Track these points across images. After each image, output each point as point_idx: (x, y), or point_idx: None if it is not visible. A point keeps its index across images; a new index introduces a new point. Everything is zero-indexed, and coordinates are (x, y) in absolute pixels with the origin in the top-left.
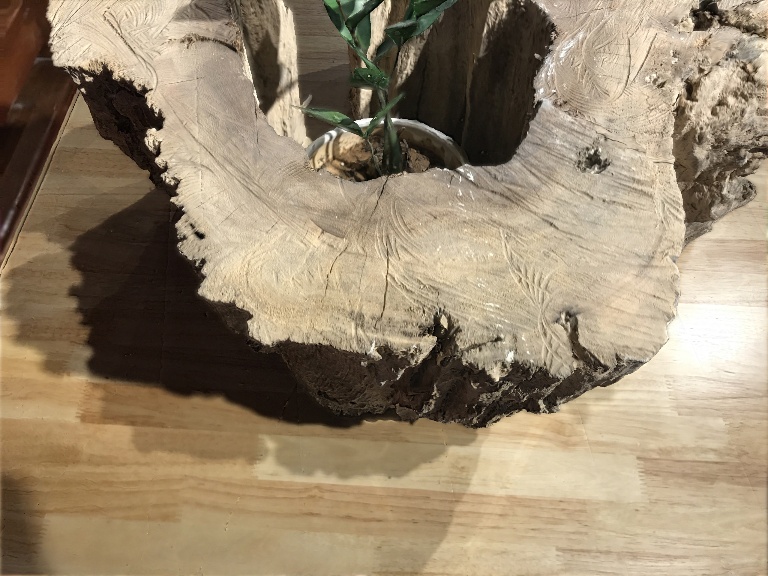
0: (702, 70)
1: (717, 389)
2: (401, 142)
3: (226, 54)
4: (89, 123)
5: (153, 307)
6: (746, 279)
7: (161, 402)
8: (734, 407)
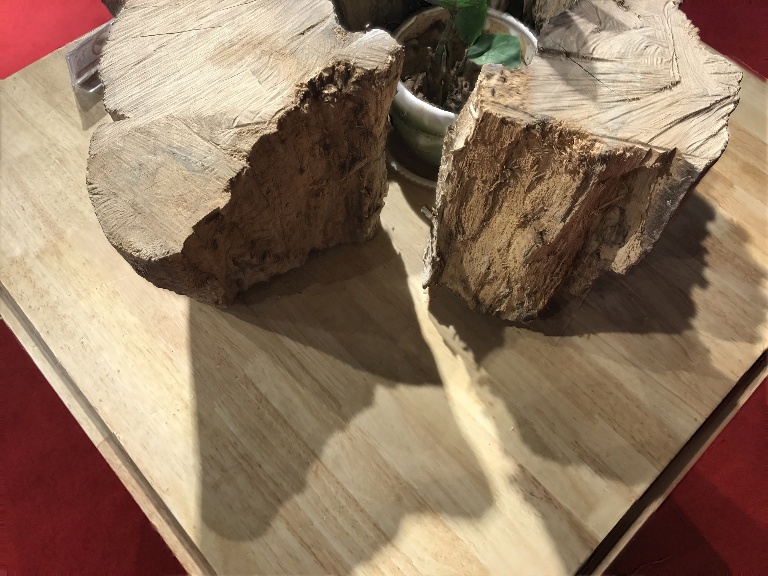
0: None
1: None
2: None
3: None
4: (609, 482)
5: None
6: None
7: None
8: None
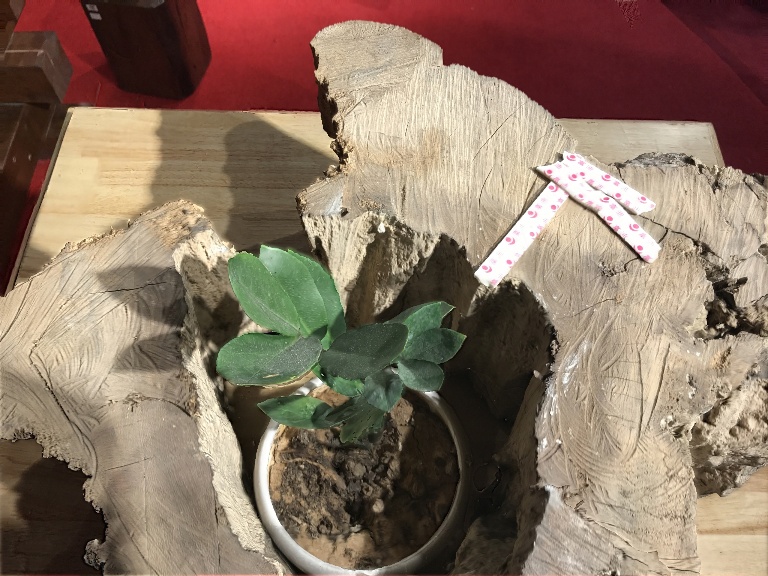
0: (721, 397)
1: None
2: None
3: (178, 419)
4: None
5: None
6: (749, 499)
7: None
8: None
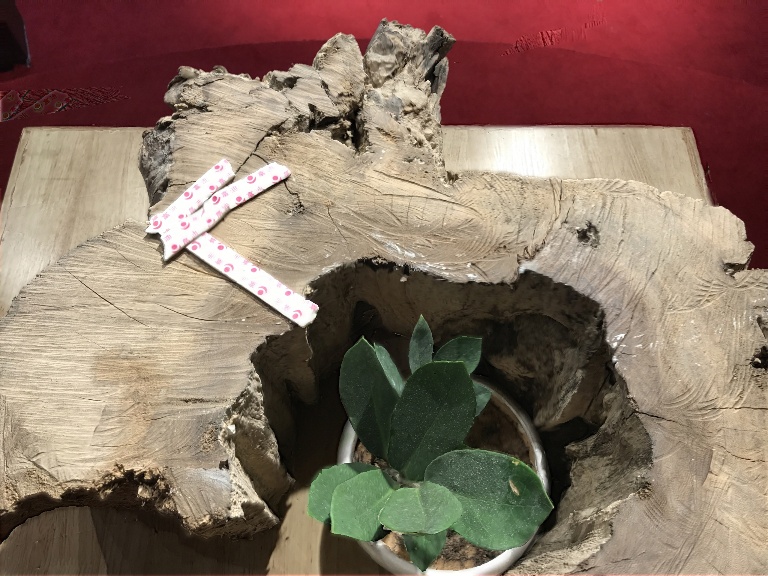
0: None
1: None
2: (353, 458)
3: None
4: None
5: None
6: None
7: None
8: None
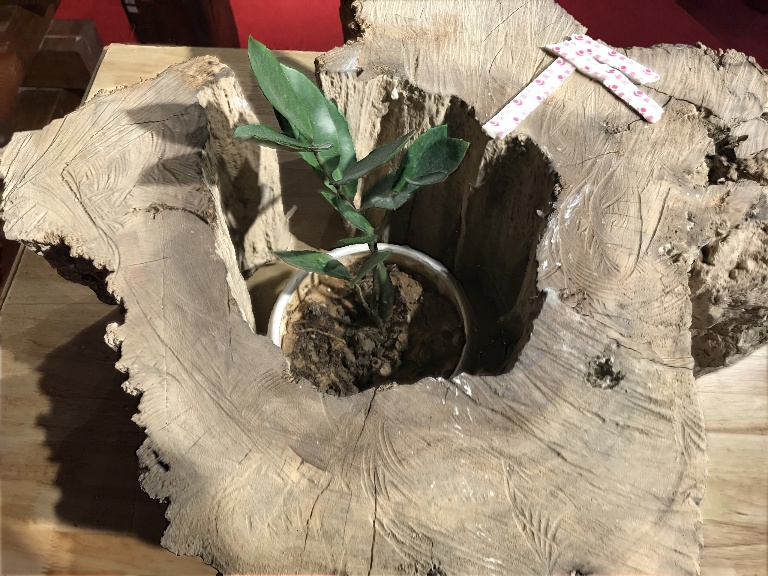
0: (720, 234)
1: (729, 534)
2: None
3: (197, 226)
4: None
5: (127, 439)
6: (758, 402)
7: (134, 554)
8: (747, 556)
